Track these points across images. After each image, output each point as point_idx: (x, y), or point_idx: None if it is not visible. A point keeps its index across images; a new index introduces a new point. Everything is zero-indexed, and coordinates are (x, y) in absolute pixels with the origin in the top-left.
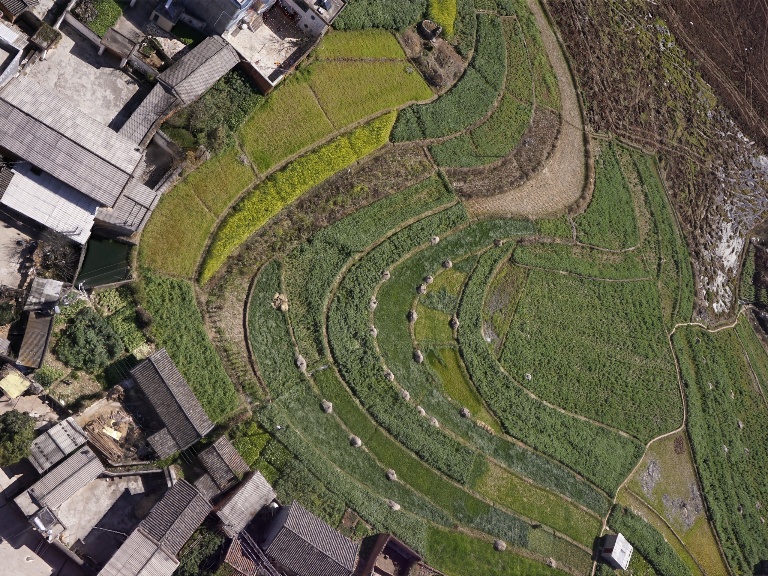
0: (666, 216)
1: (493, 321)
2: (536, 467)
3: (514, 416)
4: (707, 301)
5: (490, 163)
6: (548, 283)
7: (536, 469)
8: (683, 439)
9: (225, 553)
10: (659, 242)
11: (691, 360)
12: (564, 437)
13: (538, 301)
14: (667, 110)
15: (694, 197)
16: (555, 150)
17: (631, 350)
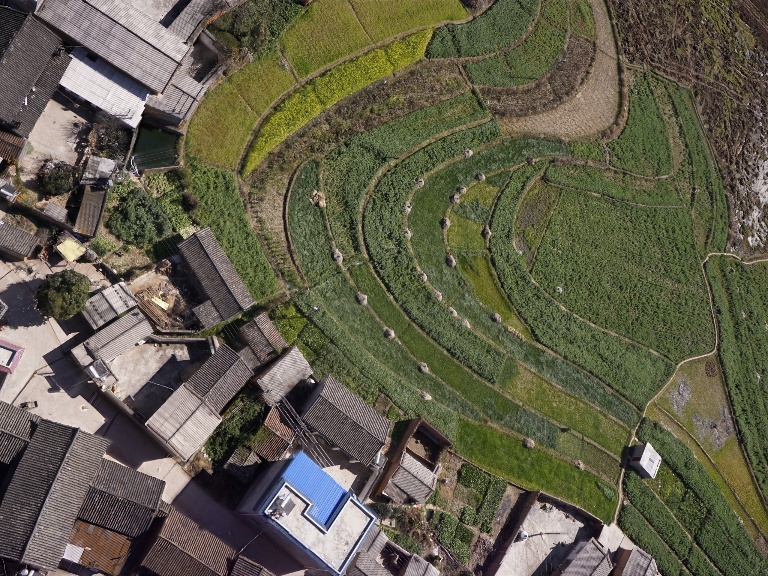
0: (701, 148)
1: (525, 235)
2: (566, 375)
3: (544, 325)
4: (742, 234)
5: (524, 84)
6: (580, 203)
7: (566, 377)
8: (715, 363)
9: (264, 418)
10: (693, 173)
11: (724, 289)
12: (594, 349)
13: (570, 220)
14: (704, 47)
15: (730, 133)
16: (589, 76)
17: (663, 274)
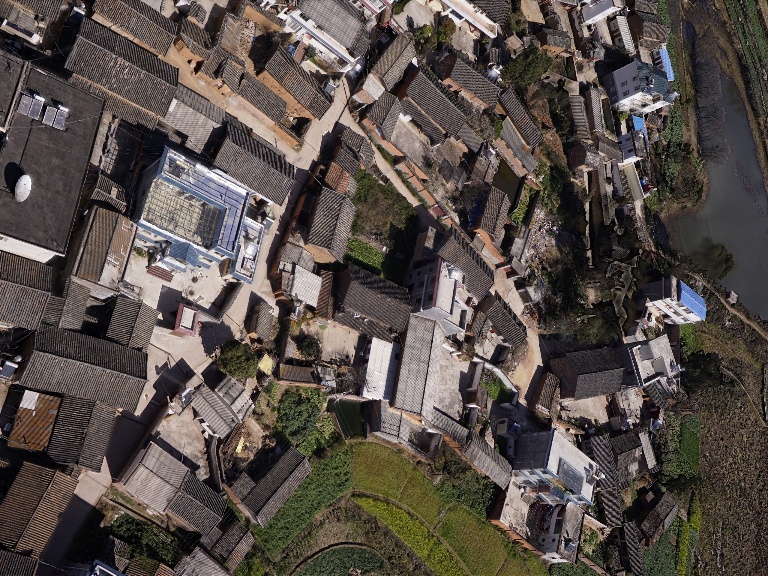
0: None
1: None
2: None
3: None
4: None
5: None
6: None
7: None
8: None
9: None
10: None
11: None
12: None
13: None
14: None
15: None
16: None
17: None
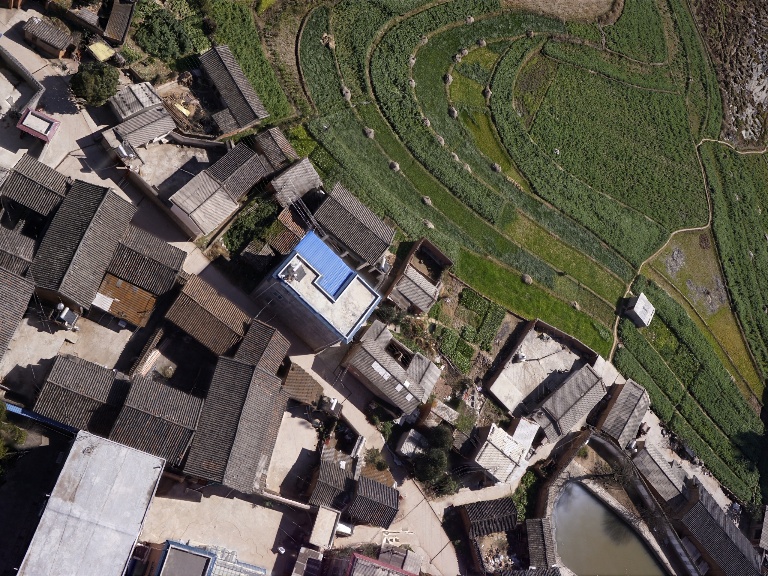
0: (695, 44)
1: (524, 99)
2: (563, 227)
3: (542, 180)
4: (736, 127)
5: None
6: (577, 78)
7: (563, 228)
8: (708, 237)
9: None
10: (688, 64)
11: (718, 172)
12: (590, 208)
13: (567, 91)
14: None
15: (724, 35)
16: None
17: (658, 151)
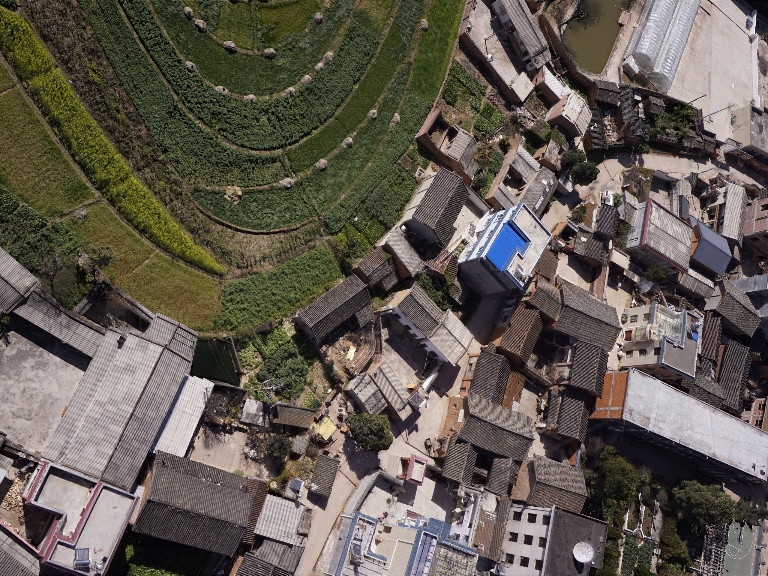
0: None
1: None
2: None
3: None
4: None
5: None
6: None
7: None
8: None
9: None
10: None
11: None
12: None
13: None
14: None
15: None
16: None
17: None
